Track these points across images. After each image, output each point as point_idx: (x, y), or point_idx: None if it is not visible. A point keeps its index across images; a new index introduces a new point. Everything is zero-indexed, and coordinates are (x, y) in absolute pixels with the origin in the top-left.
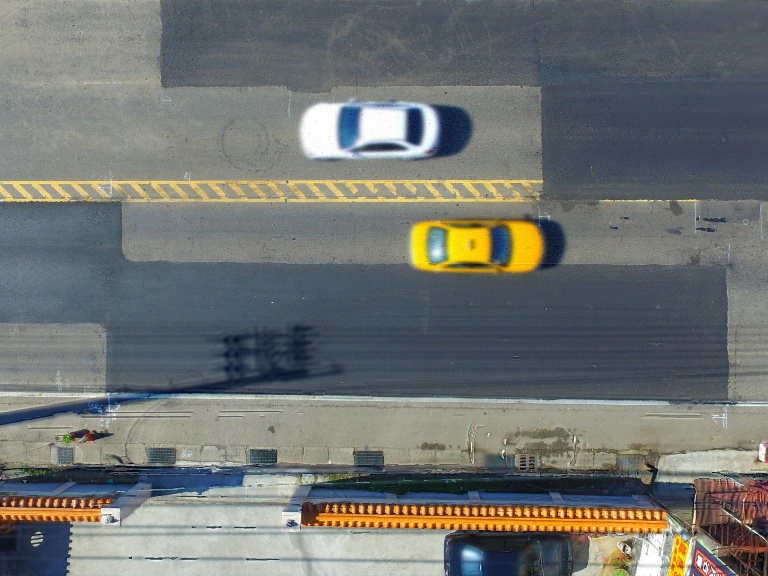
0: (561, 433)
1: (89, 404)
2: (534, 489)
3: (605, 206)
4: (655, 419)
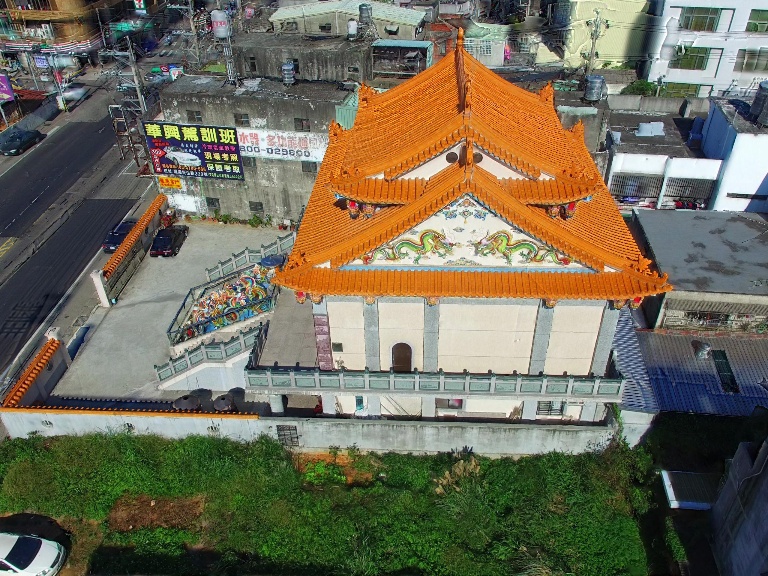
0: None
1: None
2: None
3: (37, 223)
4: (135, 213)
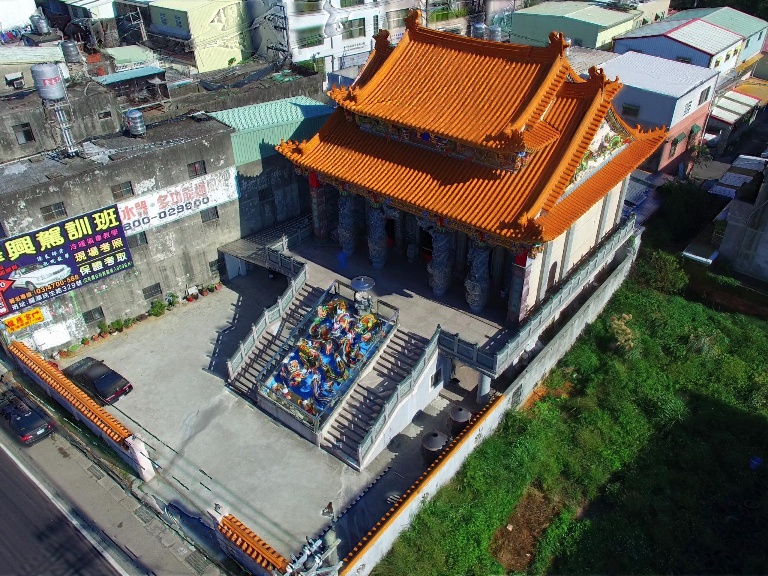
0: (8, 417)
1: None
2: (55, 403)
3: None
4: None
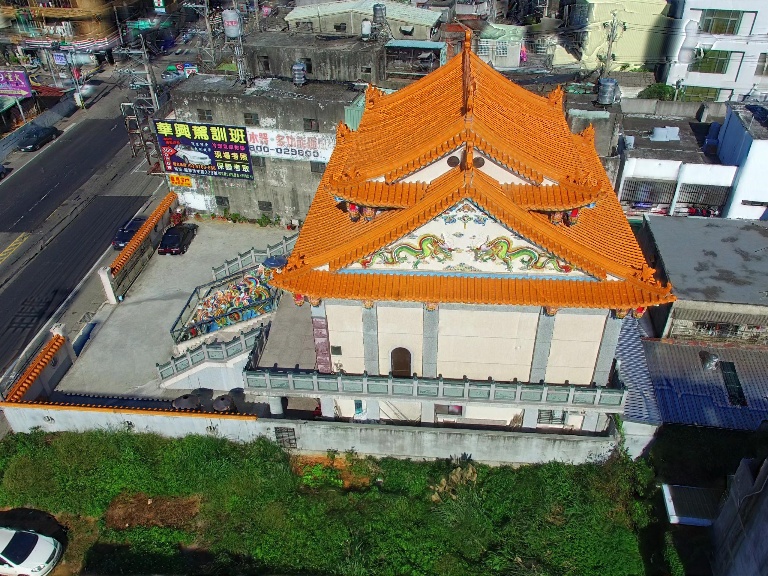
0: None
1: (2, 386)
2: None
3: (49, 219)
4: None
